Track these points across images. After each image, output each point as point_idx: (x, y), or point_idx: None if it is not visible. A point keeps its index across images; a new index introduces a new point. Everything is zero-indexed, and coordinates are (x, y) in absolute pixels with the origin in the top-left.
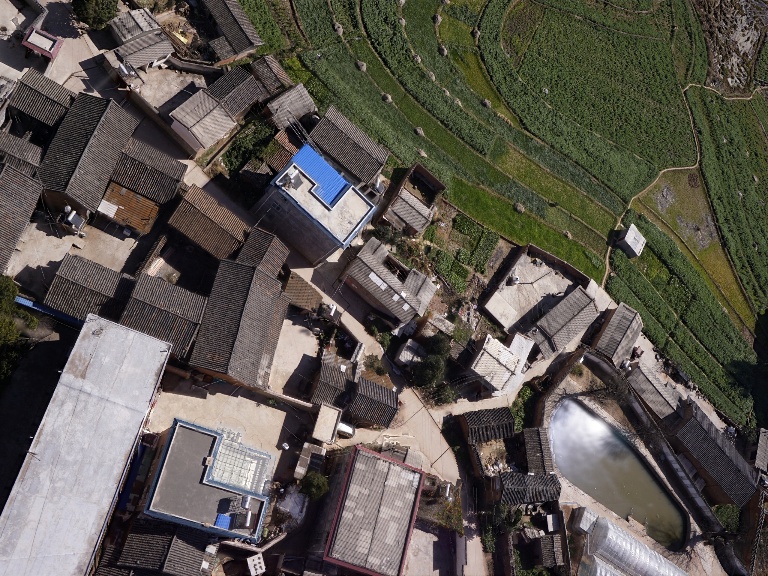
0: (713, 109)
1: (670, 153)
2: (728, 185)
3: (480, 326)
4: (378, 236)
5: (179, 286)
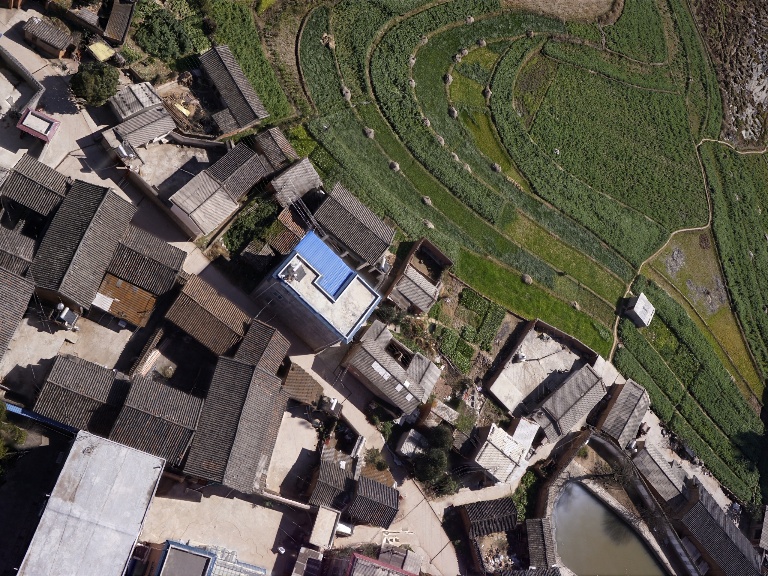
0: (726, 165)
1: (682, 213)
2: (739, 245)
3: (484, 409)
4: (382, 317)
5: (175, 379)
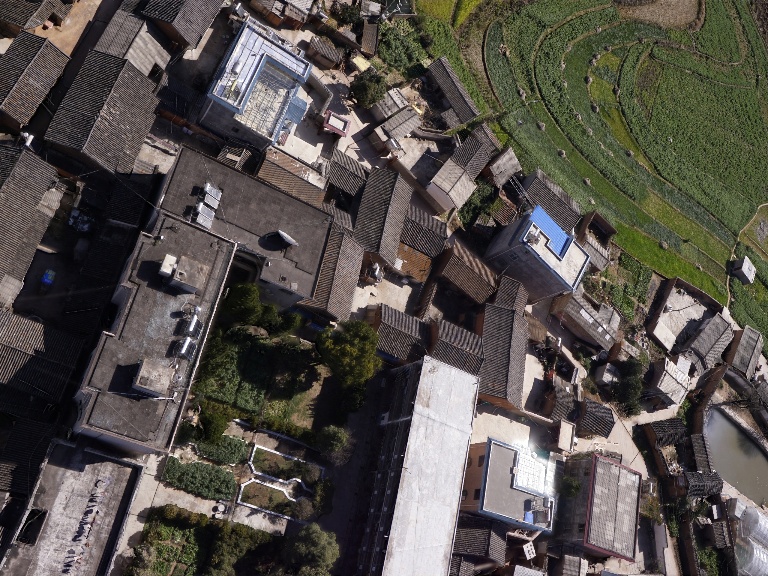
0: None
1: (763, 190)
2: None
3: (649, 349)
4: None
5: None
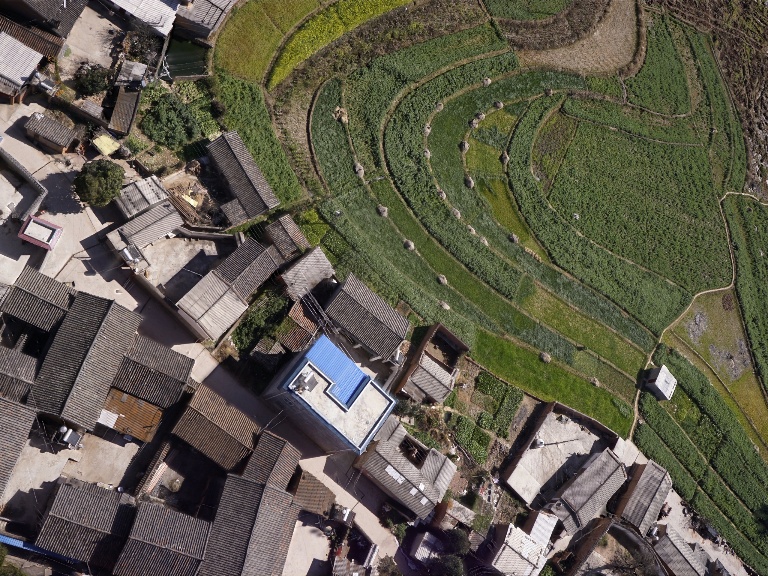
0: (750, 219)
1: (704, 274)
2: (764, 304)
3: (501, 502)
4: (396, 411)
5: (182, 493)
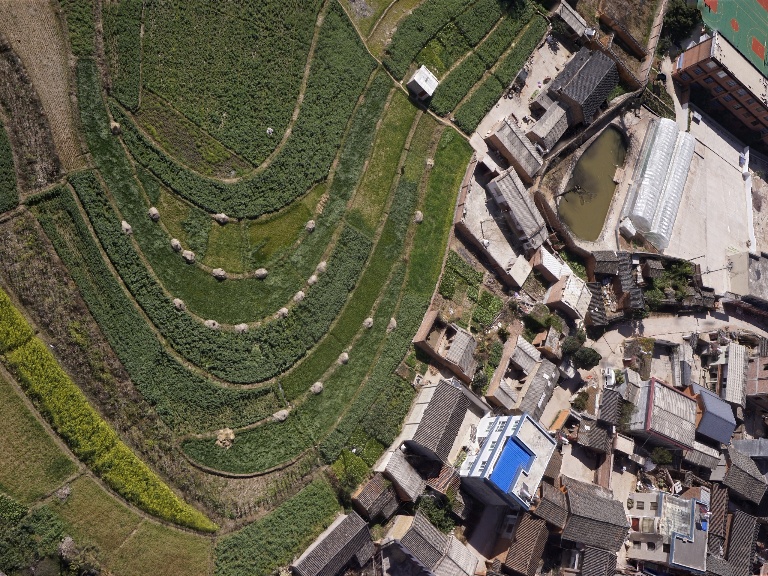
0: None
1: None
2: None
3: (529, 292)
4: None
5: (543, 556)
